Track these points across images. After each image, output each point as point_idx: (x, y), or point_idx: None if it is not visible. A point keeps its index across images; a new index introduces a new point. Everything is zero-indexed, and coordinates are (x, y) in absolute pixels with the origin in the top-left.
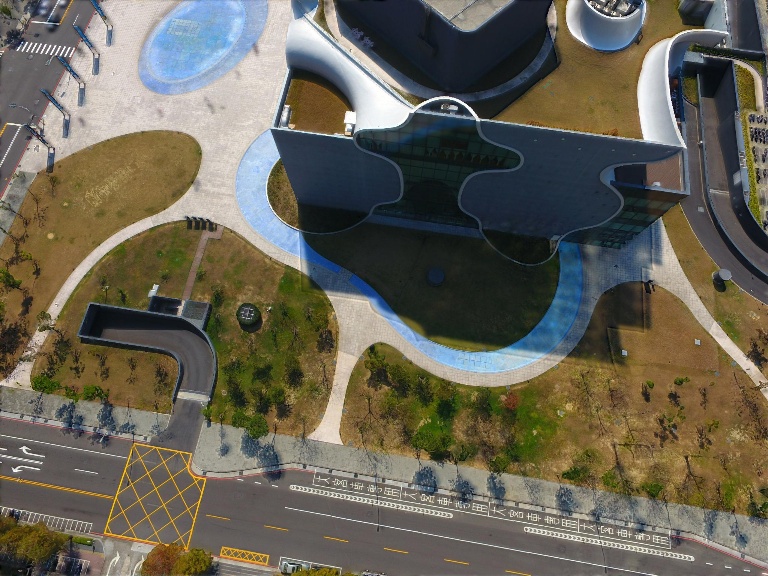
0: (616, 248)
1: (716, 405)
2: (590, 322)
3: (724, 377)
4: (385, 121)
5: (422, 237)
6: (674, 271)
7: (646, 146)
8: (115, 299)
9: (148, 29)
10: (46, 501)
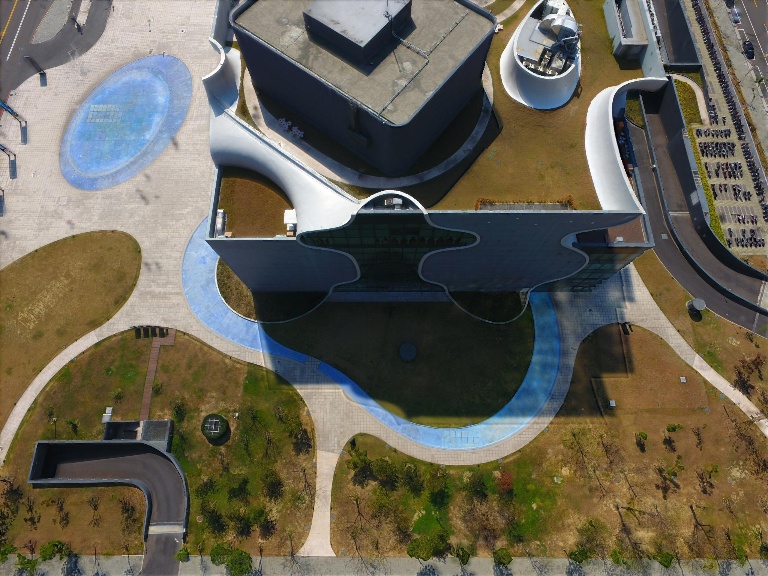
0: (587, 291)
1: (712, 444)
2: (573, 375)
3: (715, 412)
4: (327, 220)
5: (388, 309)
6: (648, 307)
7: (604, 216)
8: (65, 431)
9: (65, 120)
10: None
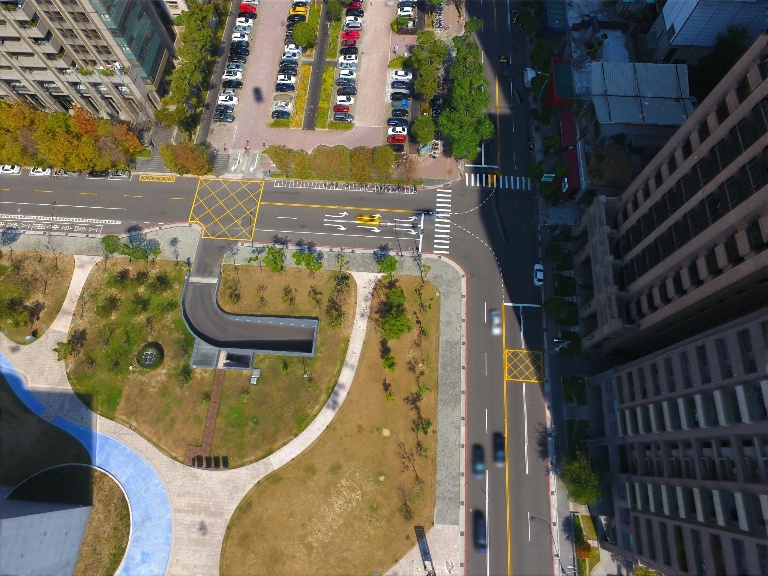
0: None
1: None
2: None
3: None
4: None
5: None
6: None
7: None
8: (294, 364)
9: None
10: (314, 197)
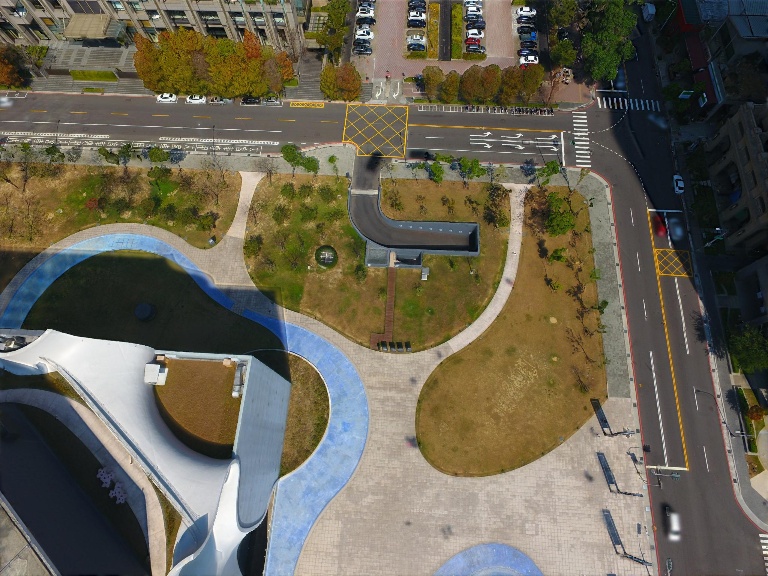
0: None
1: None
2: (7, 285)
3: None
4: (100, 351)
5: None
6: None
7: None
8: (460, 263)
9: None
10: (457, 119)
